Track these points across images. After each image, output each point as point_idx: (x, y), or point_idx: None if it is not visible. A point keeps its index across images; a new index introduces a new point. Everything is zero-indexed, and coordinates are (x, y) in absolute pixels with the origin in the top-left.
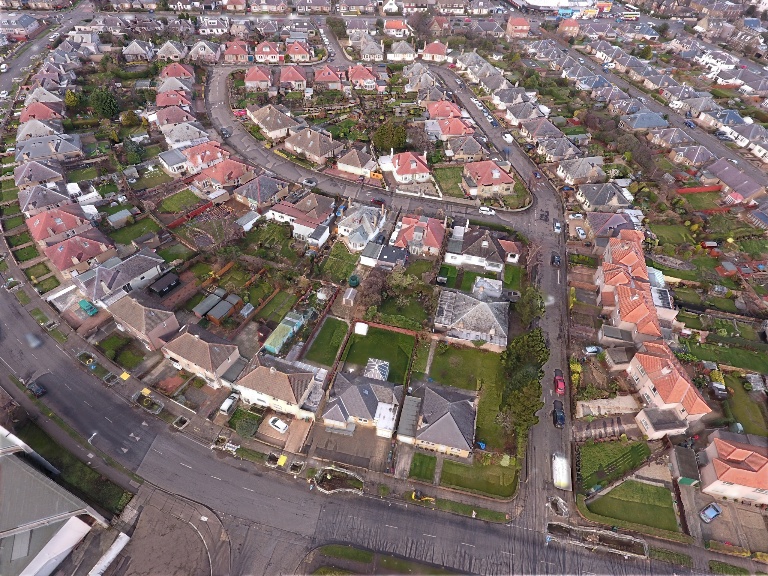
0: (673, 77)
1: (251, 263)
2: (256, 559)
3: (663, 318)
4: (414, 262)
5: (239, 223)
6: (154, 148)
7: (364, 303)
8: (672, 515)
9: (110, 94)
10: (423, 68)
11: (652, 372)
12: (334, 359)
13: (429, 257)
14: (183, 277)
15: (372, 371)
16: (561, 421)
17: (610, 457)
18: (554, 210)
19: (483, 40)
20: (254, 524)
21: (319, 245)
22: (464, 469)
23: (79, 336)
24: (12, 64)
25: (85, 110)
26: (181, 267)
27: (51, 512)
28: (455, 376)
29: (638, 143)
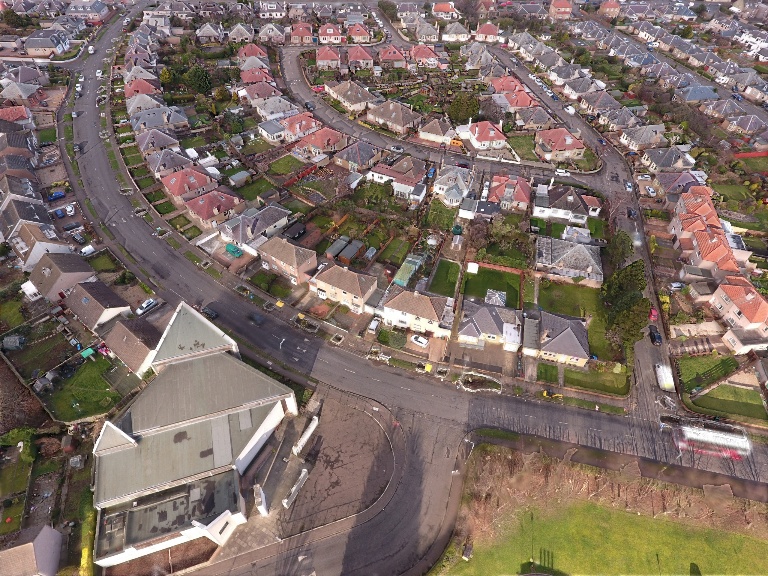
0: (717, 54)
1: (365, 215)
2: (425, 438)
3: (737, 259)
4: (506, 215)
5: (346, 182)
6: (249, 120)
7: (474, 246)
8: (763, 410)
9: (205, 71)
10: (481, 47)
11: (737, 299)
12: (454, 292)
13: (518, 211)
14: (307, 227)
15: (493, 299)
16: (659, 340)
17: (705, 367)
18: (623, 172)
19: (530, 21)
20: (417, 413)
21: (420, 201)
22: (582, 375)
23: (232, 273)
24: (96, 46)
25: (178, 87)
26: (305, 218)
27: (266, 395)
28: (561, 306)
29: (693, 113)
